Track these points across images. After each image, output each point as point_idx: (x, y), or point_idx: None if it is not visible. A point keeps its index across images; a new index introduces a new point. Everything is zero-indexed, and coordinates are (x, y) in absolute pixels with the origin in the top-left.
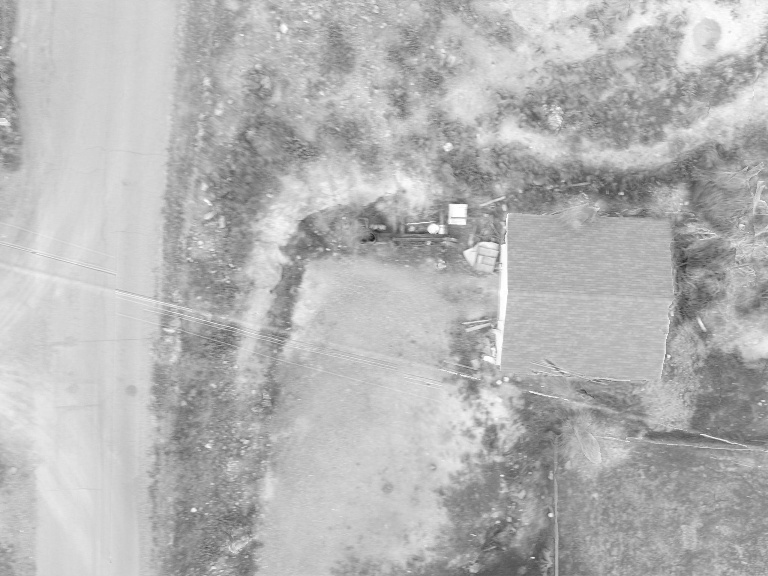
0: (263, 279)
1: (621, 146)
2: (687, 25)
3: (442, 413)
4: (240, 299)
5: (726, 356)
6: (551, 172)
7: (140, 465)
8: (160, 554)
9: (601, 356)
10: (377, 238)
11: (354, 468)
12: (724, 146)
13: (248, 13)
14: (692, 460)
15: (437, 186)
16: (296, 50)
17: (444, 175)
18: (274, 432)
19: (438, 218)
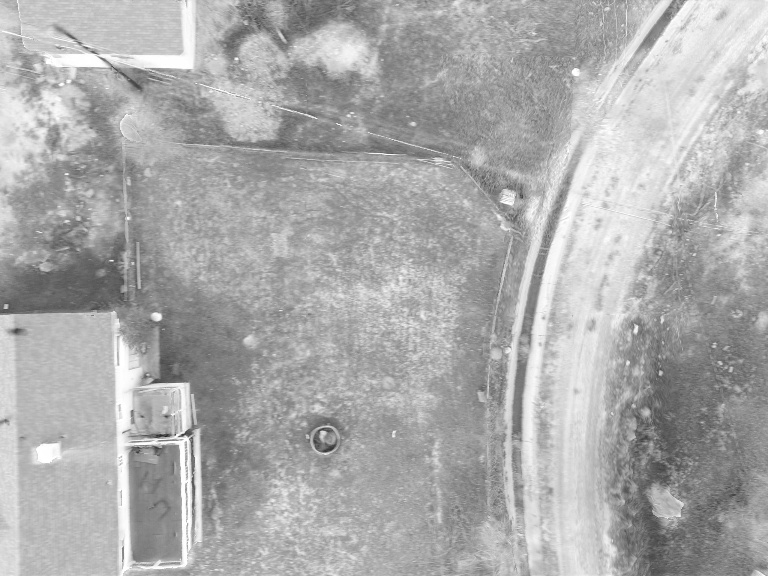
0: None
1: None
2: None
3: (5, 116)
4: None
5: (311, 69)
6: None
7: None
8: None
9: (120, 28)
10: None
11: None
12: None
13: None
14: (281, 170)
15: None
16: None
17: None
18: None
19: None
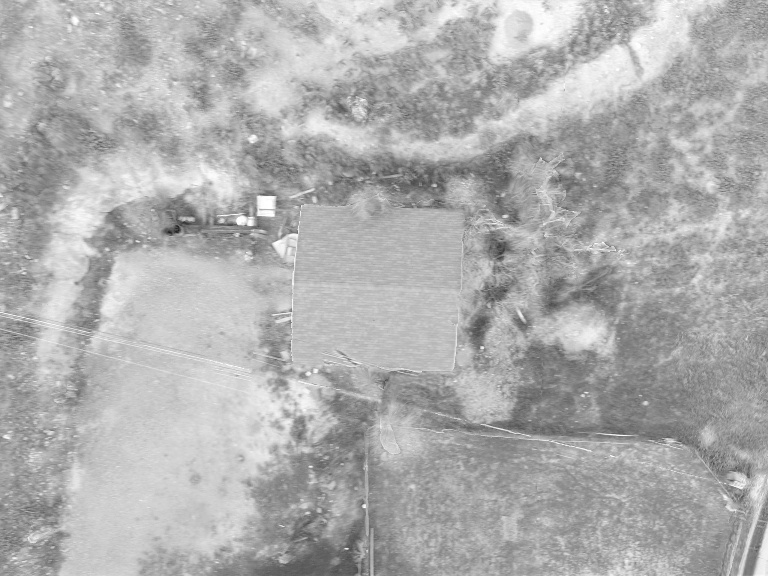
0: (64, 271)
1: (431, 138)
2: (498, 17)
3: (251, 404)
4: (38, 290)
5: (548, 348)
6: (360, 164)
7: None
8: None
9: (392, 347)
10: (186, 230)
11: (162, 459)
12: (539, 138)
13: (37, 5)
14: (513, 452)
15: (243, 178)
16: (89, 42)
17: (246, 167)
18: (81, 423)
19: (247, 210)
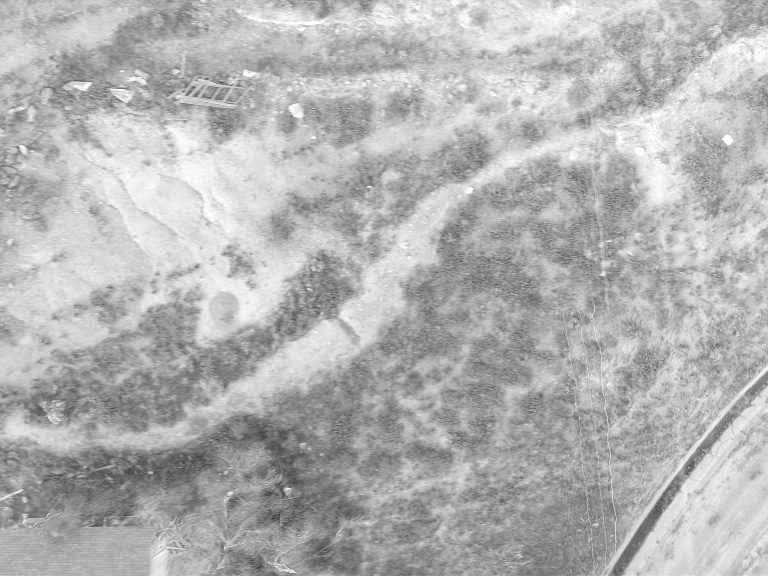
0: None
1: (138, 430)
2: (201, 300)
3: None
4: None
5: None
6: (68, 462)
7: None
8: None
9: None
10: None
11: None
12: (256, 415)
13: None
14: None
15: None
16: None
17: None
18: None
19: None
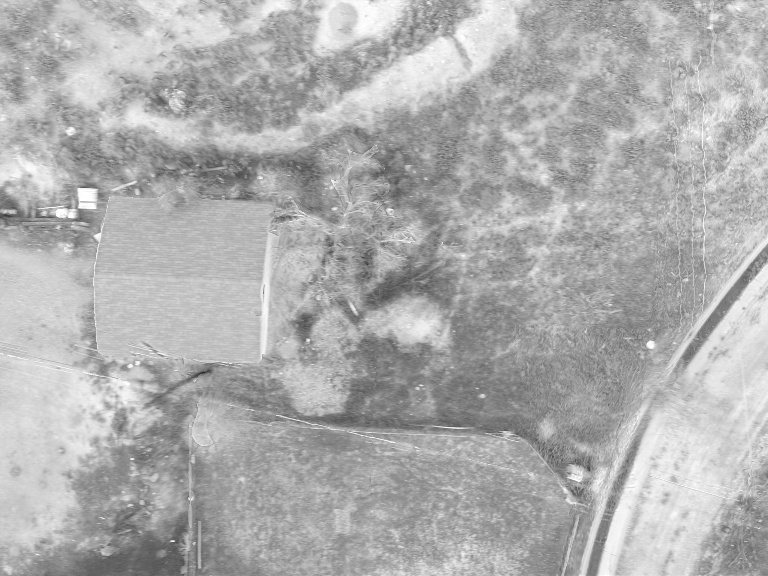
0: None
1: (253, 130)
2: (322, 9)
3: (72, 397)
4: None
5: (381, 340)
6: (182, 156)
7: None
8: None
9: (197, 338)
10: (8, 222)
11: None
12: (366, 130)
13: None
14: (346, 444)
15: (63, 170)
16: None
17: (62, 159)
18: None
19: (69, 202)
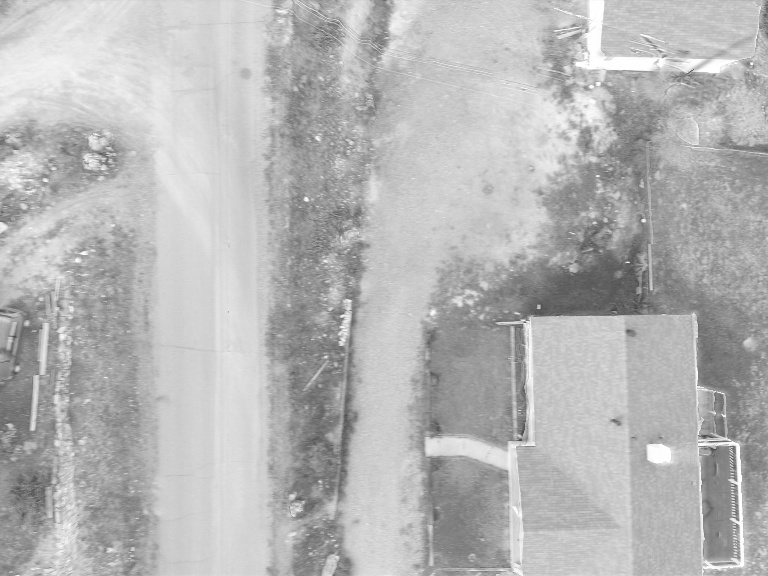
0: None
1: None
2: None
3: (538, 117)
4: None
5: None
6: None
7: (256, 148)
8: (277, 237)
9: (697, 32)
10: None
11: (455, 171)
12: None
13: None
14: None
15: None
16: None
17: None
18: (376, 137)
19: None
